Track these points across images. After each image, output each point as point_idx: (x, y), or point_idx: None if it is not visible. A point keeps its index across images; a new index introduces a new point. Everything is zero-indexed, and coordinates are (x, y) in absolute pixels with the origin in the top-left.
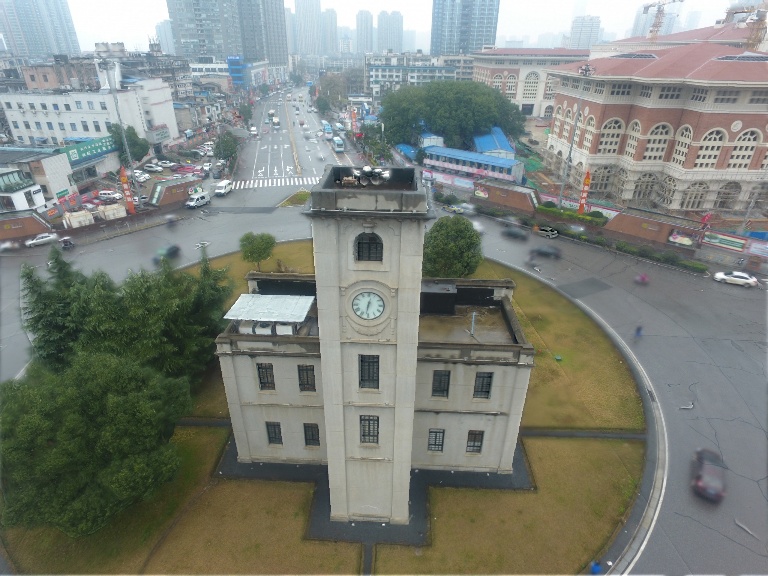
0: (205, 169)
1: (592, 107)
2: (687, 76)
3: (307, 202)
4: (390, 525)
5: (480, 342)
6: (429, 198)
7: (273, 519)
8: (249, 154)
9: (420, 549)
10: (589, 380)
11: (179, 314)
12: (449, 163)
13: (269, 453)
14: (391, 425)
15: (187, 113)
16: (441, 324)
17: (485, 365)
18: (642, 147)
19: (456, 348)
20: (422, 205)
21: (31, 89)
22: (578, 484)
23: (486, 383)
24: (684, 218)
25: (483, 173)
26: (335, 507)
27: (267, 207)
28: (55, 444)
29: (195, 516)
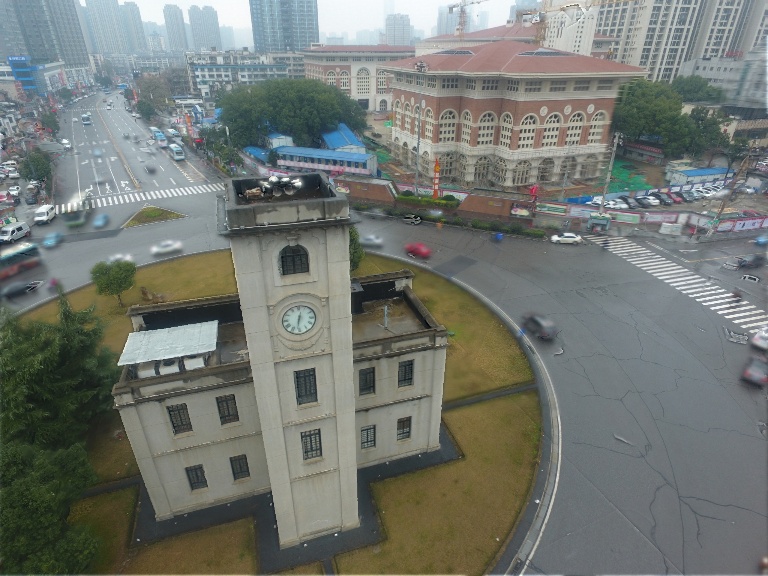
0: (12, 194)
1: (428, 100)
2: (501, 70)
3: (219, 221)
4: (342, 533)
5: (396, 333)
6: None
7: (217, 569)
8: (67, 171)
9: (377, 546)
10: (481, 347)
11: (42, 372)
12: (304, 162)
13: (193, 501)
14: (333, 434)
15: None
16: (354, 324)
17: (406, 354)
18: (475, 134)
19: (378, 344)
20: (345, 210)
21: None
22: (496, 441)
23: (408, 371)
24: (519, 193)
25: (340, 169)
26: (284, 534)
27: (109, 230)
28: None
29: None
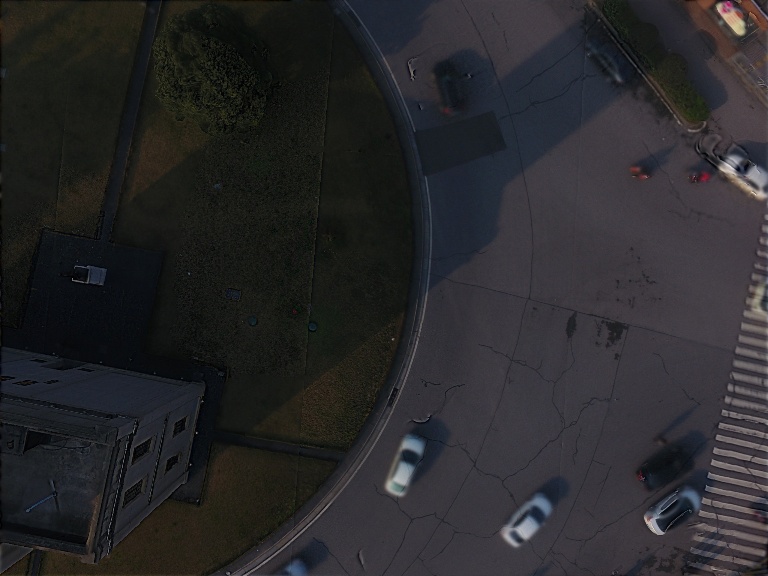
0: None
1: None
2: None
3: None
4: None
5: (59, 510)
6: None
7: None
8: None
9: None
10: (329, 372)
11: None
12: None
13: None
14: None
15: None
16: (23, 464)
17: None
18: None
19: None
20: None
21: None
22: (239, 505)
23: None
24: None
25: None
26: None
27: None
28: None
29: None
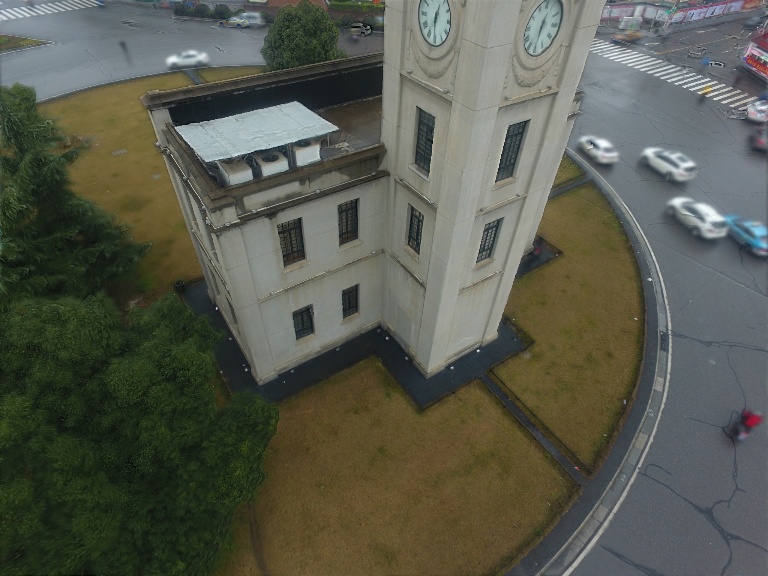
0: None
1: None
2: None
3: None
4: (483, 348)
5: None
6: (191, 15)
7: (369, 414)
8: None
9: (526, 351)
10: None
11: (17, 221)
12: None
13: (297, 353)
14: (513, 224)
15: None
16: None
17: None
18: None
19: None
20: None
21: None
22: (584, 234)
23: None
24: None
25: None
26: (433, 360)
27: None
28: (65, 512)
29: (271, 473)
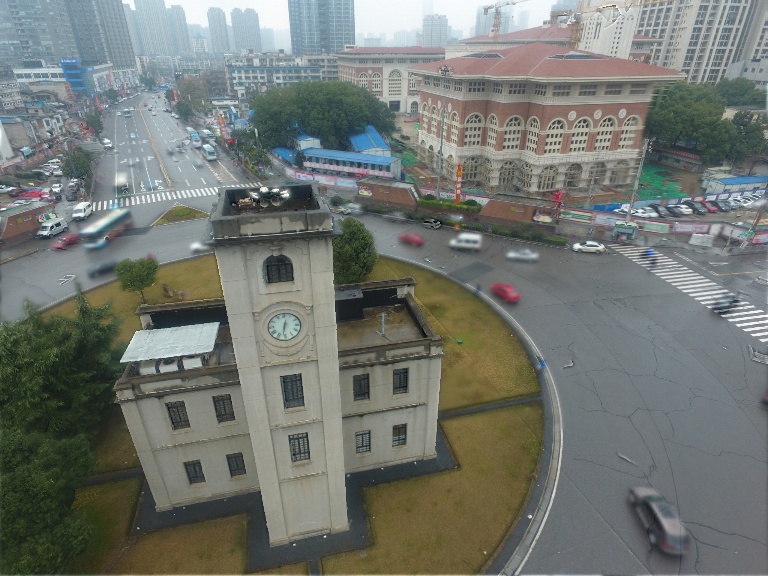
0: (55, 191)
1: (454, 104)
2: (529, 74)
3: None
4: (331, 535)
5: (392, 341)
6: None
7: (208, 562)
8: (107, 170)
9: (364, 551)
10: (488, 357)
11: (59, 364)
12: (329, 164)
13: (191, 494)
14: (321, 438)
15: (20, 128)
16: (353, 329)
17: (400, 362)
18: (501, 138)
19: (372, 351)
20: (327, 223)
21: None
22: (494, 453)
23: (403, 379)
24: (543, 199)
25: (364, 172)
26: (273, 532)
27: (139, 227)
28: None
29: None
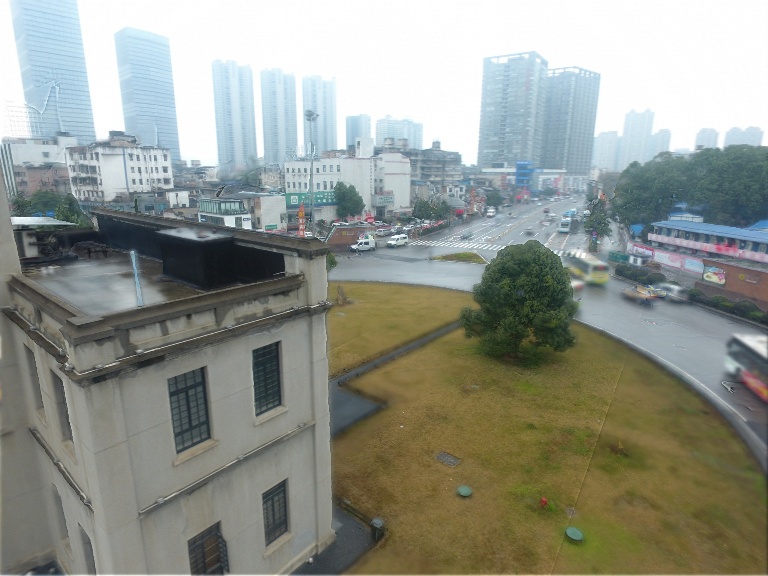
0: (405, 229)
1: None
2: None
3: None
4: None
5: None
6: (626, 276)
7: None
8: (464, 226)
9: None
10: None
11: None
12: (683, 239)
13: None
14: None
15: (426, 189)
16: (156, 291)
17: None
18: None
19: None
20: None
21: (299, 156)
22: None
23: None
24: None
25: (735, 253)
26: None
27: (417, 258)
28: None
29: None
